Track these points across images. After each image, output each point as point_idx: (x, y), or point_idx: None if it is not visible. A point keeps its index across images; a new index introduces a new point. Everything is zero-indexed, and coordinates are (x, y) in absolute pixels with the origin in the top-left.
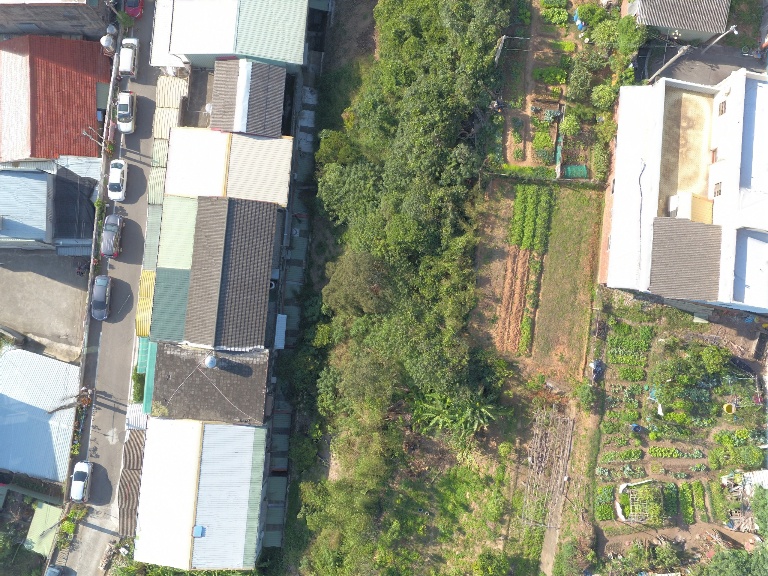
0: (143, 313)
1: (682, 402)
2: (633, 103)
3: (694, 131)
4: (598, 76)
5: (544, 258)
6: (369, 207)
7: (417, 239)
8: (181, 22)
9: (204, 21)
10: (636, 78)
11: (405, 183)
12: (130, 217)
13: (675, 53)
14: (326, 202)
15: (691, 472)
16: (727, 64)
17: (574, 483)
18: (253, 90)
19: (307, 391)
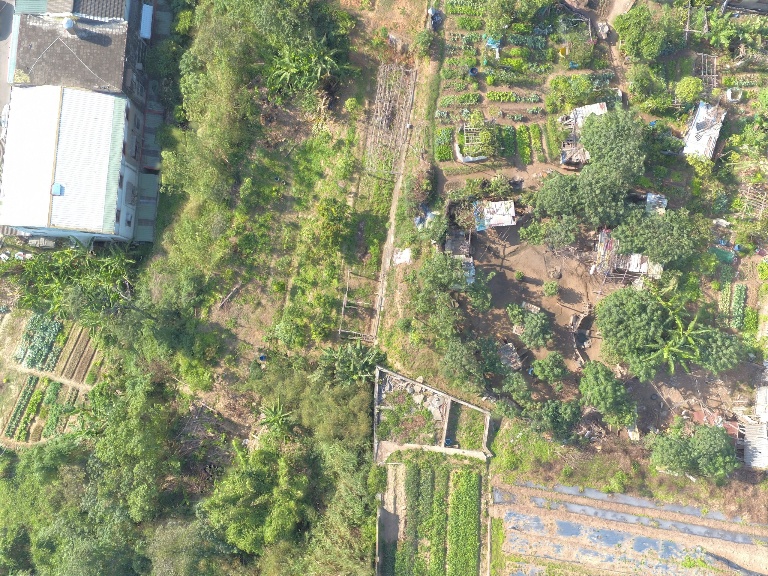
0: None
1: (519, 49)
2: None
3: None
4: None
5: None
6: None
7: None
8: None
9: None
10: None
11: None
12: None
13: None
14: None
15: (528, 115)
16: None
17: (416, 129)
18: None
19: (173, 81)
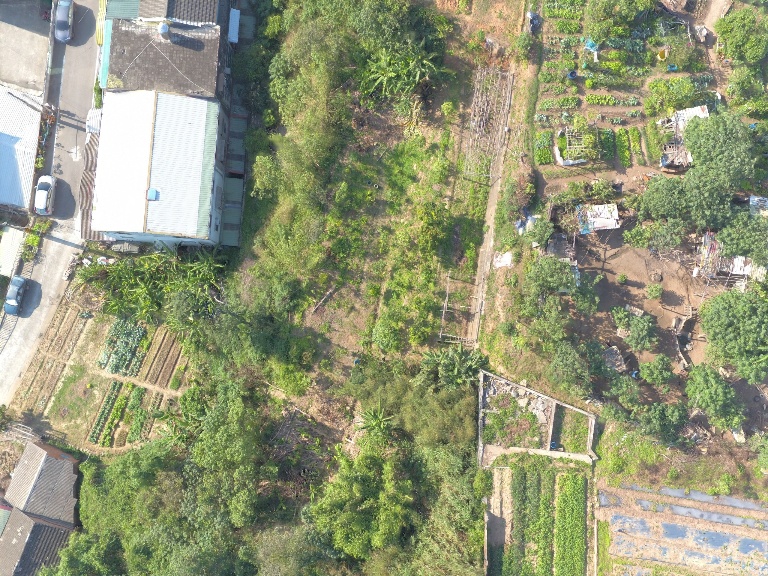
0: (103, 21)
1: (617, 52)
2: None
3: None
4: None
5: None
6: None
7: None
8: None
9: None
10: None
11: None
12: None
13: None
14: None
15: (627, 118)
16: None
17: (514, 133)
18: None
19: (261, 85)
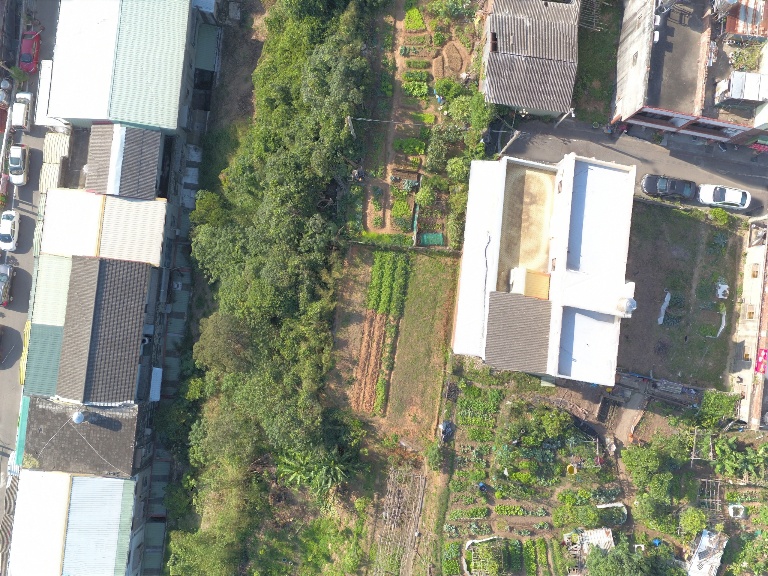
0: None
1: (528, 462)
2: (482, 177)
3: (536, 207)
4: (456, 147)
5: (400, 322)
6: (236, 269)
7: (273, 304)
8: (59, 86)
9: (81, 86)
10: (490, 151)
11: (266, 249)
12: (21, 266)
13: (529, 127)
14: (200, 261)
15: (535, 530)
16: (578, 138)
17: (424, 539)
18: (126, 154)
19: (182, 442)
